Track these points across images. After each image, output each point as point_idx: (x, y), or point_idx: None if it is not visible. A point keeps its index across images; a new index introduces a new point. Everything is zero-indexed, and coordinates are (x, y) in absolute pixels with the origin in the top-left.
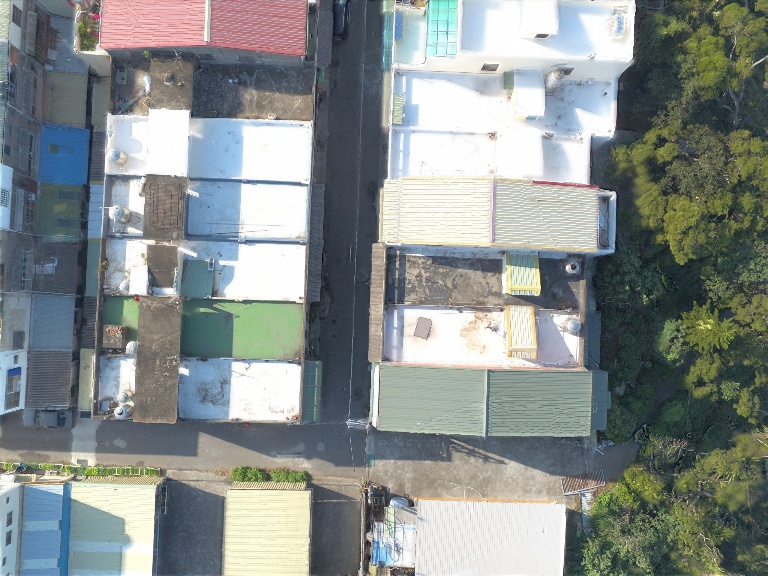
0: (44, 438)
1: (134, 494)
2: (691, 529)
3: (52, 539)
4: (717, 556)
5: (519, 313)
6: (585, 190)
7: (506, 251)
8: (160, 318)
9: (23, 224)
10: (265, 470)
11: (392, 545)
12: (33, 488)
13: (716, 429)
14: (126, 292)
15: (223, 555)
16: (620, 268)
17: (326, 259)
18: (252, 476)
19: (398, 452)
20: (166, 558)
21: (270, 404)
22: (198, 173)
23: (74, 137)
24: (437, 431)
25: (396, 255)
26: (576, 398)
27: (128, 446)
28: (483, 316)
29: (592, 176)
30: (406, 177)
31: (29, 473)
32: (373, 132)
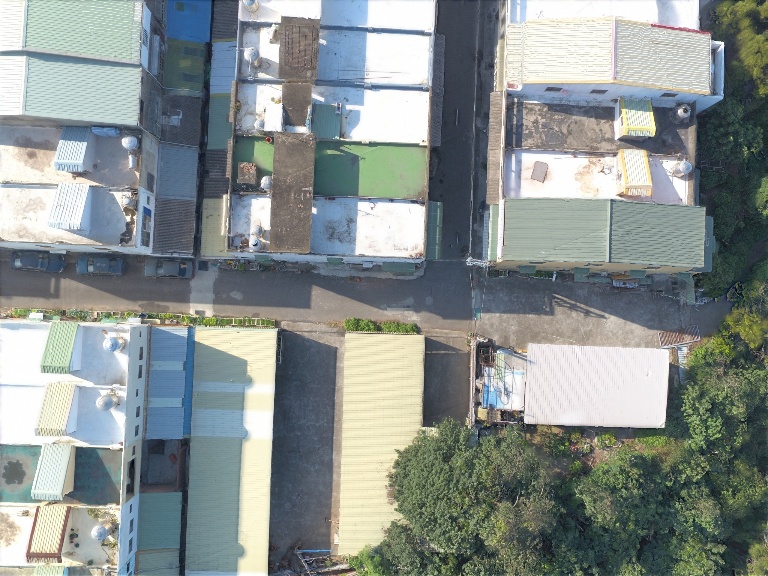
0: (163, 289)
1: (256, 337)
2: None
3: (177, 379)
4: None
5: (633, 155)
6: (698, 36)
7: (620, 97)
8: (295, 153)
9: (158, 68)
10: (376, 322)
11: (502, 389)
12: (159, 329)
13: None
14: (261, 129)
15: (336, 403)
16: (724, 120)
17: None
18: (365, 326)
19: (503, 306)
20: (281, 406)
21: (394, 242)
22: (325, 22)
23: None
24: (561, 258)
25: (514, 102)
26: (691, 231)
27: (244, 298)
28: (597, 161)
29: (700, 29)
30: (530, 20)
31: None
32: None
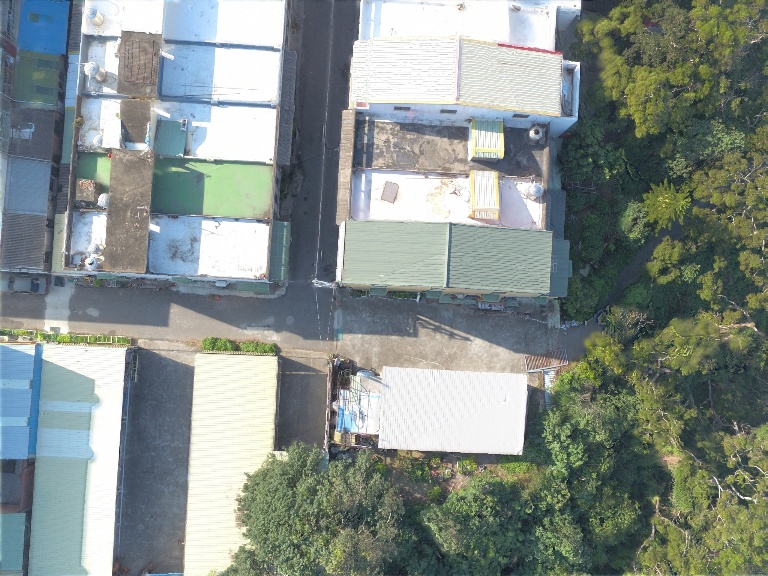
0: (18, 305)
1: (104, 356)
2: (650, 406)
3: (23, 397)
4: (678, 444)
5: (483, 177)
6: (549, 57)
7: (472, 117)
8: (132, 170)
9: (0, 82)
10: (235, 342)
11: (357, 412)
12: (5, 347)
13: (679, 321)
14: (99, 145)
15: None
16: (583, 141)
17: (299, 138)
18: (222, 346)
19: (366, 327)
20: (135, 425)
21: (239, 262)
22: (173, 36)
23: (54, 8)
24: (400, 283)
25: (365, 121)
26: (536, 256)
27: (101, 315)
28: (449, 182)
29: (557, 48)
30: (375, 38)
31: (2, 336)
32: (348, 16)
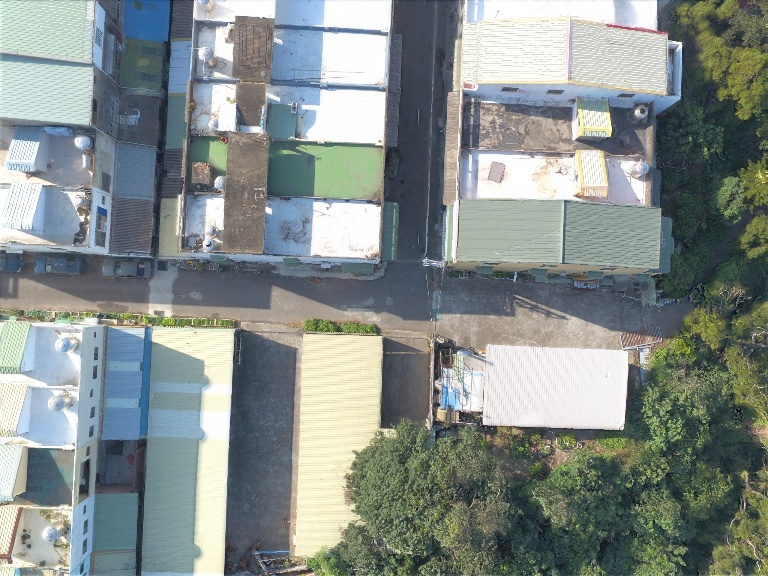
0: (122, 289)
1: (213, 337)
2: (745, 380)
3: (134, 379)
4: None
5: (590, 156)
6: (654, 37)
7: (577, 97)
8: (248, 153)
9: (113, 68)
10: (336, 323)
11: (461, 390)
12: (116, 329)
13: (763, 299)
14: (215, 129)
15: (295, 404)
16: (683, 120)
17: None
18: (324, 327)
19: (464, 307)
20: (240, 406)
21: (350, 242)
22: (282, 21)
23: None
24: (515, 259)
25: (471, 102)
26: (646, 232)
27: (204, 298)
28: (554, 161)
29: (658, 29)
30: (485, 20)
31: (110, 319)
32: (440, 1)
